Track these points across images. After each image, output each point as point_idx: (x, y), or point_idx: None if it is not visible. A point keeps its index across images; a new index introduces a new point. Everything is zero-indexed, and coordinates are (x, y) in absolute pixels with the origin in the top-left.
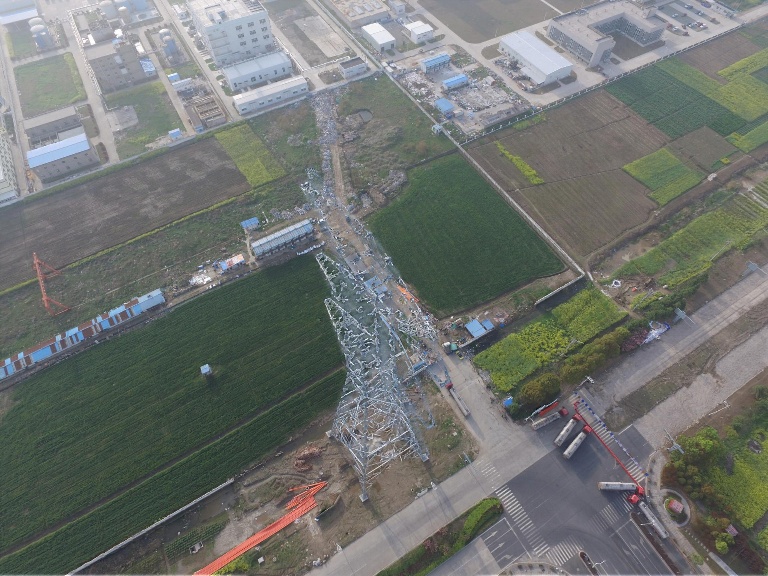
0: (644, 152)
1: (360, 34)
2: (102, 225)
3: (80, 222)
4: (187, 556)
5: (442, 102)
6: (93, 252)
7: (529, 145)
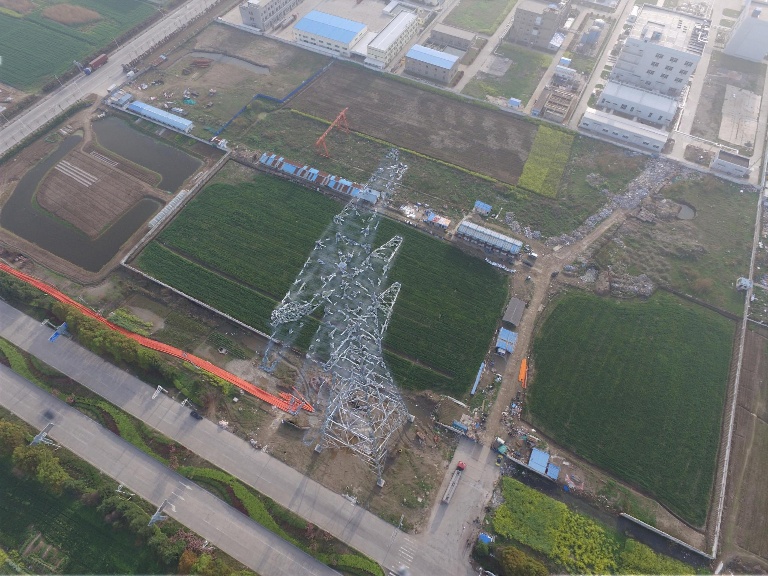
0: None
1: None
2: (401, 125)
3: (393, 112)
4: (215, 349)
5: None
6: (378, 136)
7: None
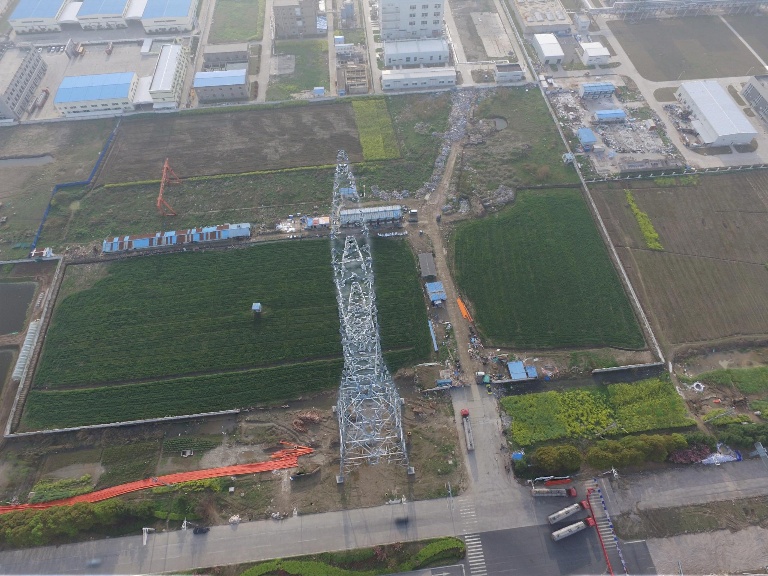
0: None
1: (531, 41)
2: (229, 153)
3: (213, 144)
4: (178, 456)
5: (585, 132)
6: (213, 173)
7: (664, 205)
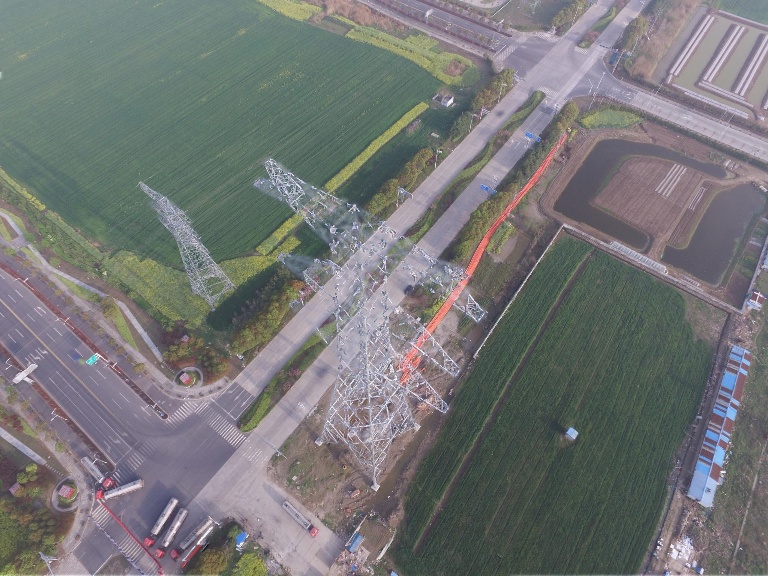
0: None
1: None
2: None
3: None
4: None
5: None
6: None
7: None
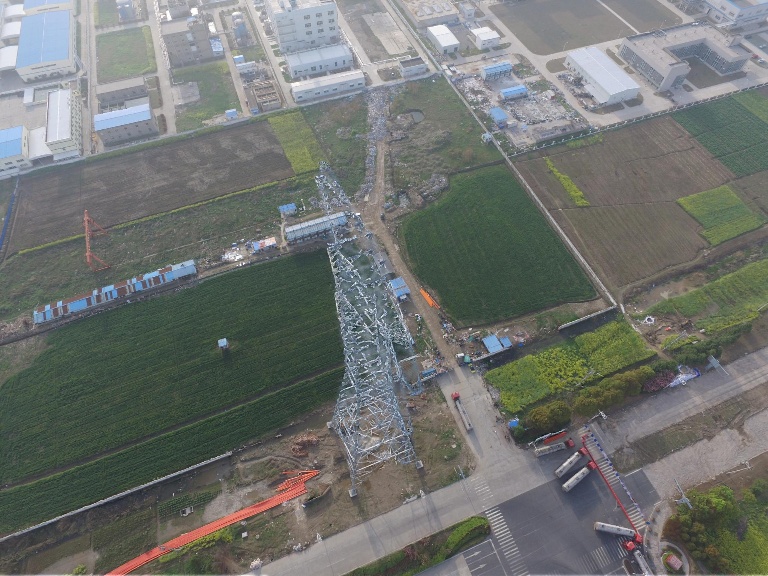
0: (703, 187)
1: (425, 34)
2: (151, 192)
3: (132, 187)
4: (177, 517)
5: (496, 111)
6: (139, 217)
7: (580, 165)
